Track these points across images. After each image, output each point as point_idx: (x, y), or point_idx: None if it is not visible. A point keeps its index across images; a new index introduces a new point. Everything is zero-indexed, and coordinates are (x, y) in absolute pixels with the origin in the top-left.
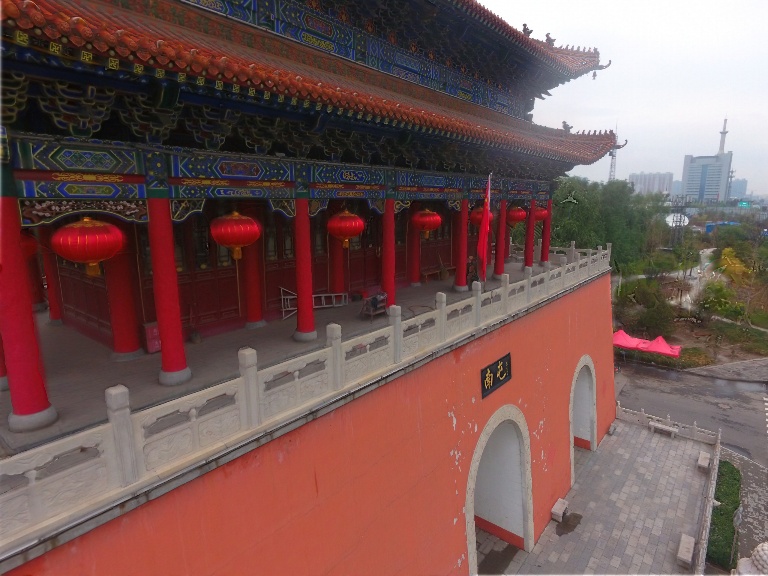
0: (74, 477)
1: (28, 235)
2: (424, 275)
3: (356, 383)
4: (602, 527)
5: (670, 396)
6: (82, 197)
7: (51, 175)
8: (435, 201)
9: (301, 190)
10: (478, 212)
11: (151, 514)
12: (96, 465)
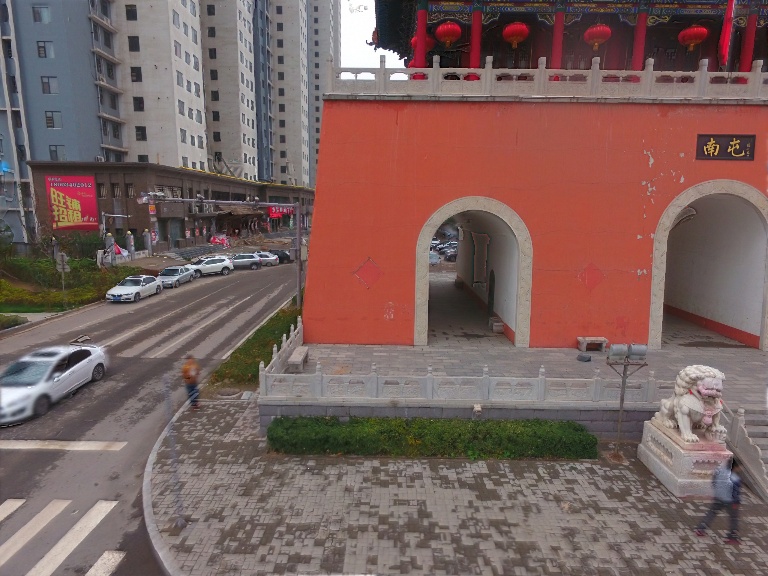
0: (420, 83)
1: (431, 34)
2: None
3: None
4: None
5: None
6: (448, 11)
7: (439, 3)
8: (704, 17)
9: (559, 7)
10: None
11: (440, 108)
12: (426, 82)
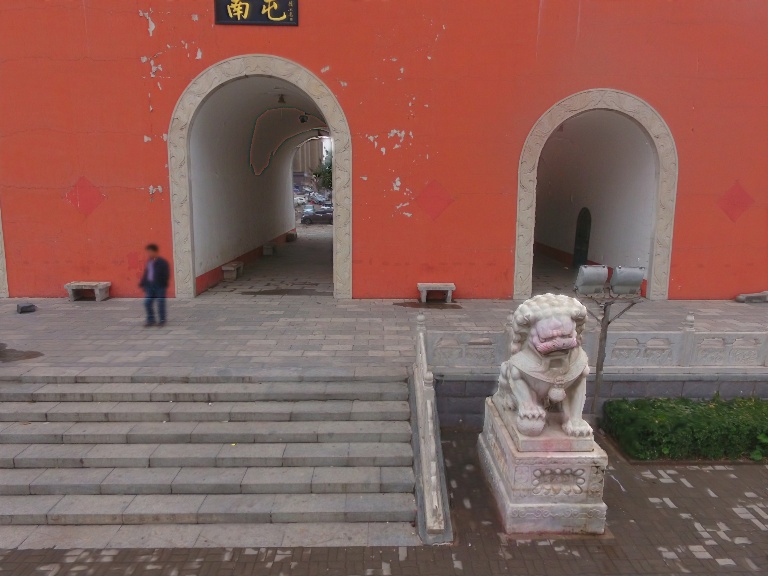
0: None
1: None
2: None
3: None
4: (460, 317)
5: None
6: None
7: None
8: None
9: None
10: None
11: None
12: None
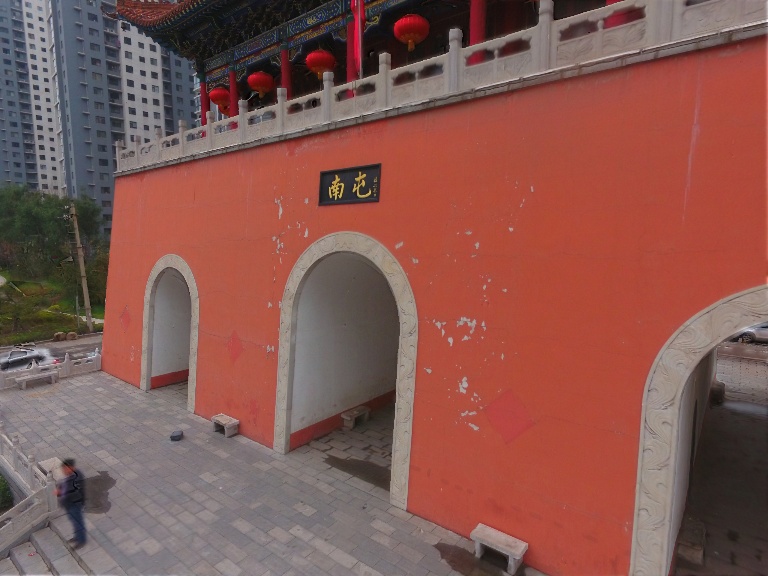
0: None
1: None
2: None
3: None
4: None
5: None
6: None
7: None
8: (419, 0)
9: None
10: None
11: None
12: None
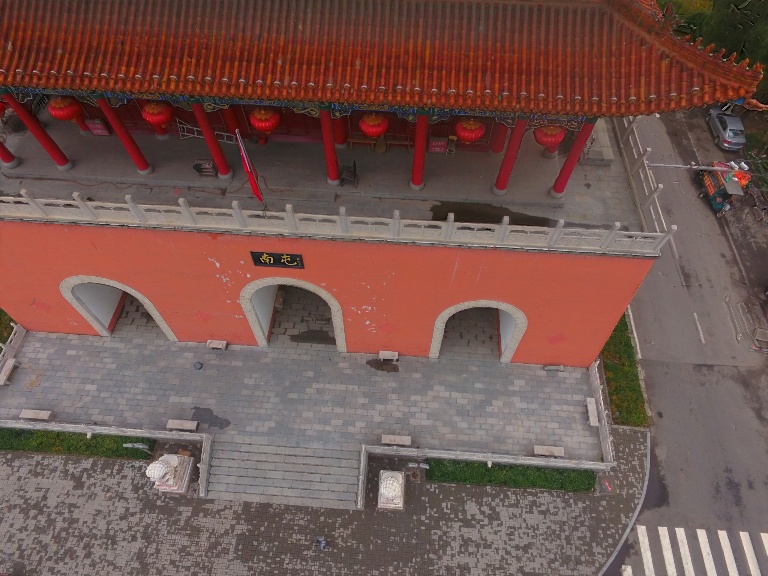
0: None
1: None
2: (348, 141)
3: (105, 221)
4: (394, 386)
5: (751, 419)
6: None
7: None
8: None
9: None
10: (363, 120)
11: None
12: None
